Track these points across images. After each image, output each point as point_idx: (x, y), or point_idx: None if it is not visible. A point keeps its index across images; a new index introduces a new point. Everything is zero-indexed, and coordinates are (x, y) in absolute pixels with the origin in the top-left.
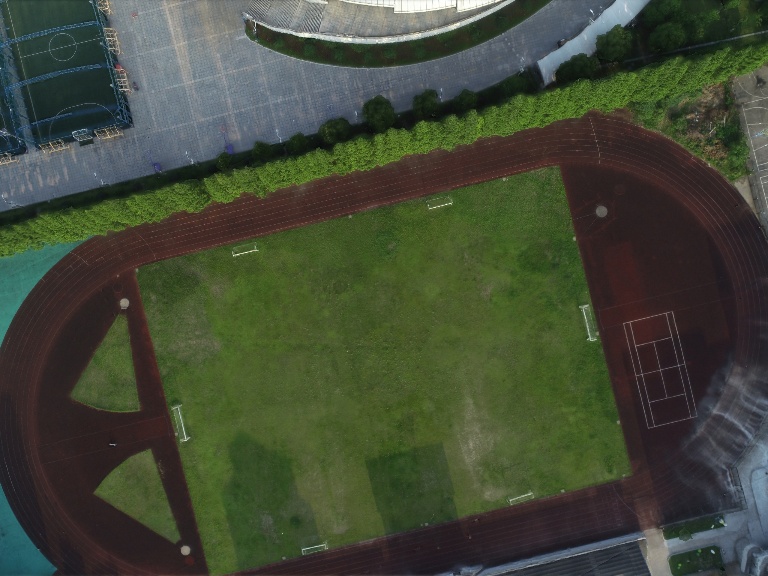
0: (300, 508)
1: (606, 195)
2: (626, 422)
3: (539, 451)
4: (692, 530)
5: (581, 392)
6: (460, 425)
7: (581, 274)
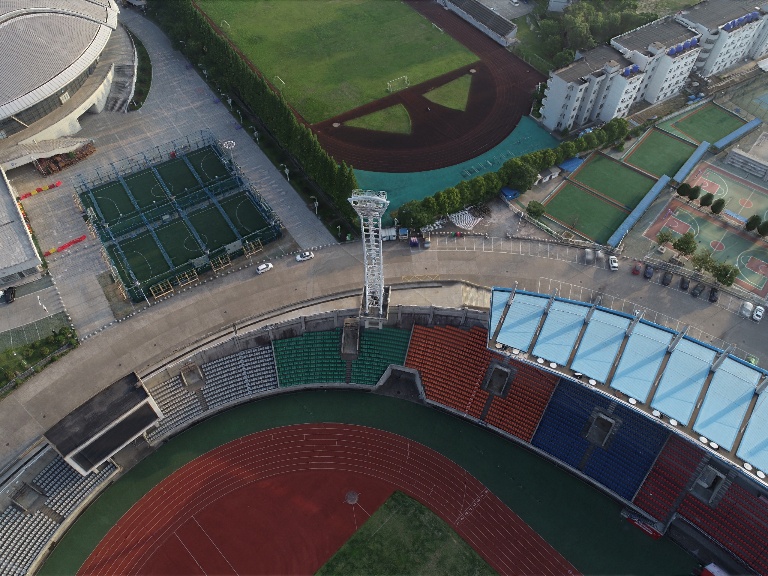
0: (420, 39)
1: None
2: None
3: None
4: None
5: None
6: (344, 2)
7: None
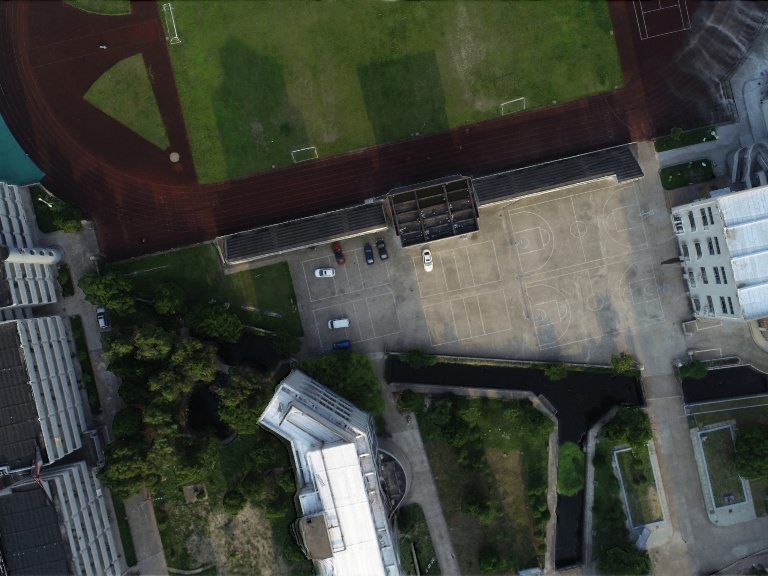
0: (290, 116)
1: None
2: (619, 33)
3: (531, 61)
4: (683, 143)
5: (575, 1)
6: (452, 33)
7: None
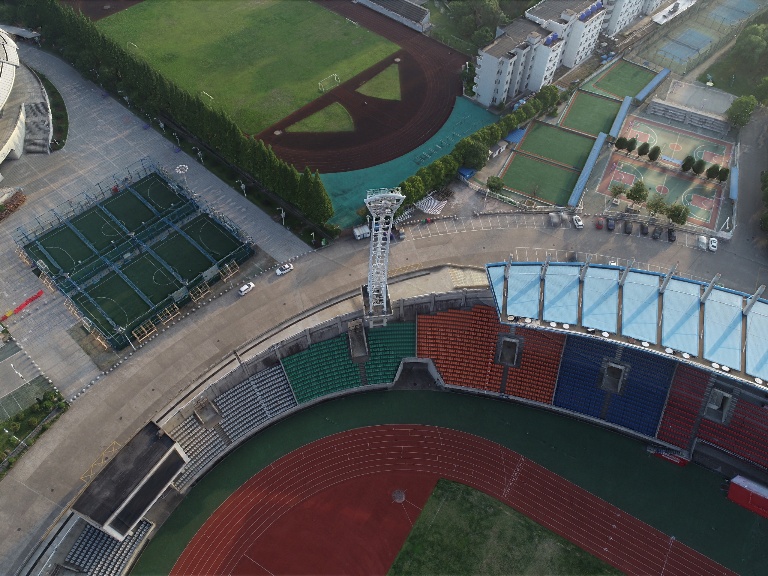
0: (338, 36)
1: (97, 9)
2: None
3: None
4: None
5: None
6: (251, 8)
7: (145, 2)
